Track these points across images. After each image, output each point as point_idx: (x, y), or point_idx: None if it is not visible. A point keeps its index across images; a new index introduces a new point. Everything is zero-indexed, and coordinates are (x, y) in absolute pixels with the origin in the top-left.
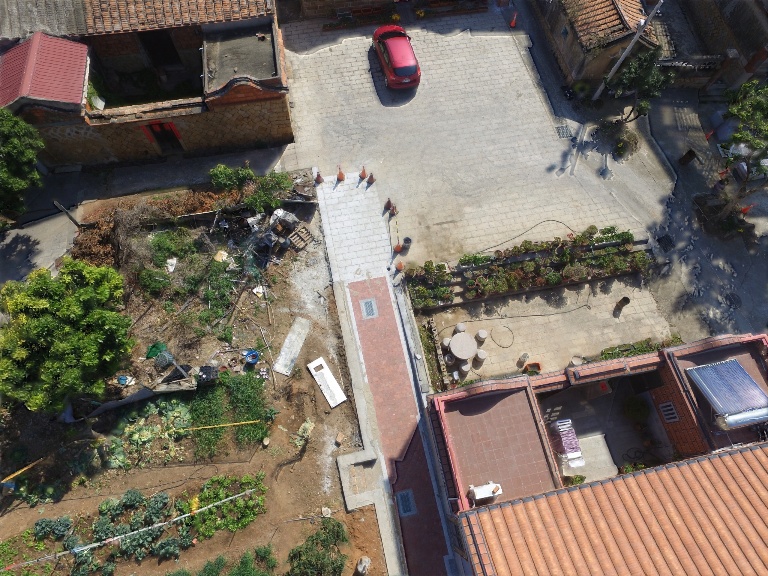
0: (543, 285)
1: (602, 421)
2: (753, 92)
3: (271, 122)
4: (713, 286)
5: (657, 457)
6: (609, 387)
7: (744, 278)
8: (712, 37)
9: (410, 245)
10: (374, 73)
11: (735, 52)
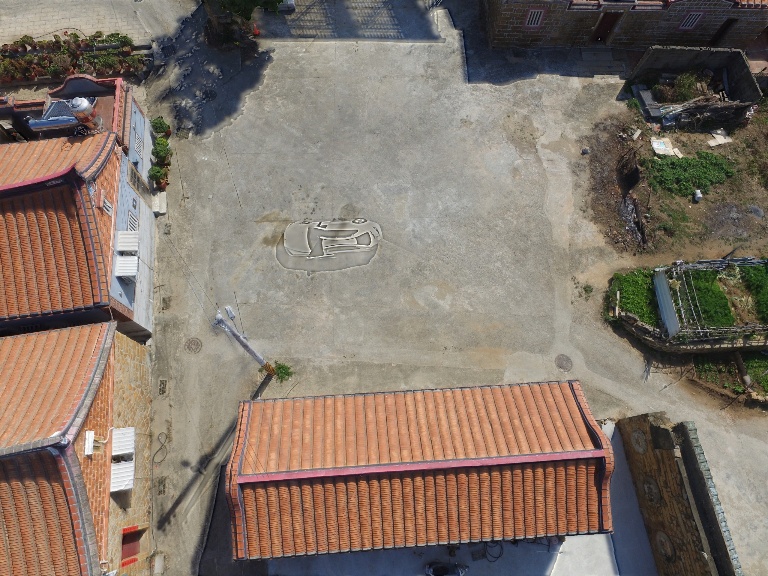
0: (51, 78)
1: None
2: None
3: None
4: (196, 84)
5: None
6: None
7: (228, 80)
8: None
9: None
10: None
11: None
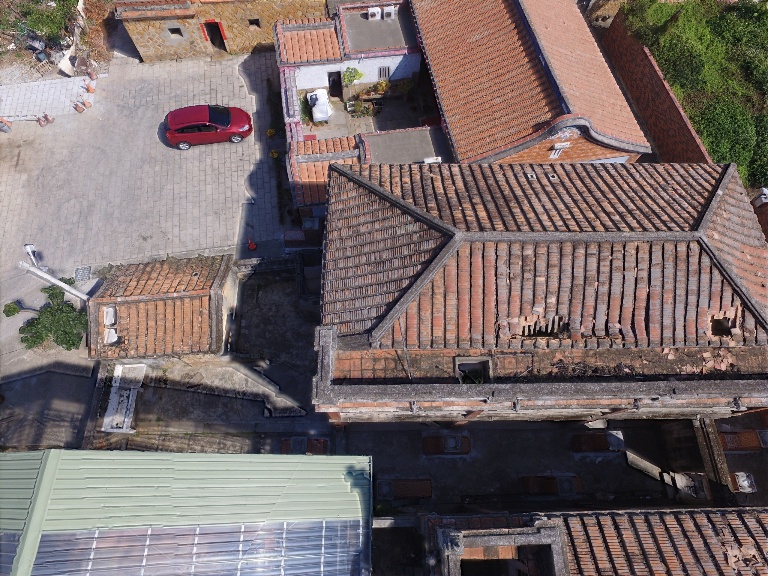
0: None
1: None
2: None
3: None
4: None
5: None
6: None
7: None
8: None
9: (7, 133)
10: None
11: None
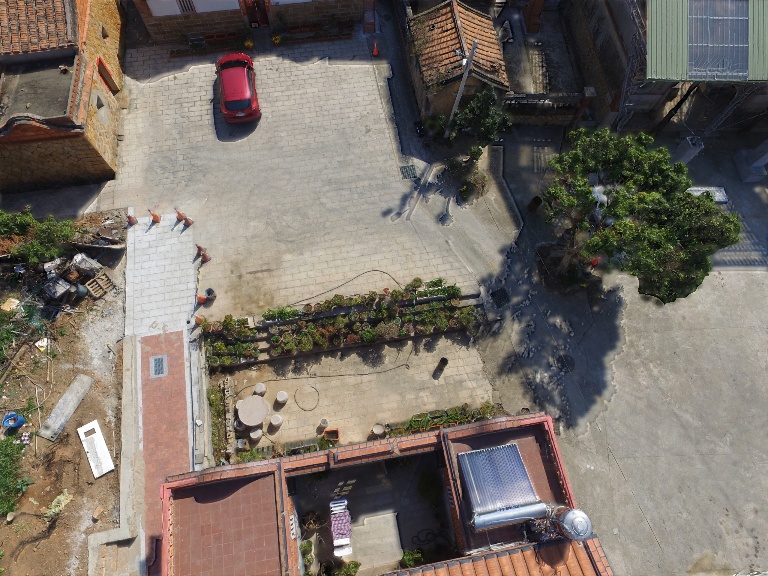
0: (360, 341)
1: (397, 497)
2: (581, 140)
3: (81, 159)
4: (545, 346)
5: (449, 541)
6: (384, 468)
7: (582, 338)
8: (588, 70)
9: (216, 296)
10: (216, 104)
11: (591, 90)
